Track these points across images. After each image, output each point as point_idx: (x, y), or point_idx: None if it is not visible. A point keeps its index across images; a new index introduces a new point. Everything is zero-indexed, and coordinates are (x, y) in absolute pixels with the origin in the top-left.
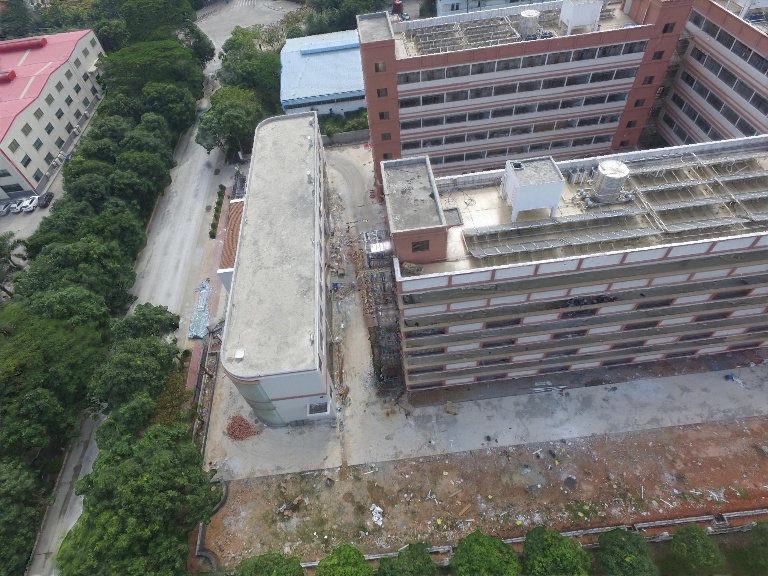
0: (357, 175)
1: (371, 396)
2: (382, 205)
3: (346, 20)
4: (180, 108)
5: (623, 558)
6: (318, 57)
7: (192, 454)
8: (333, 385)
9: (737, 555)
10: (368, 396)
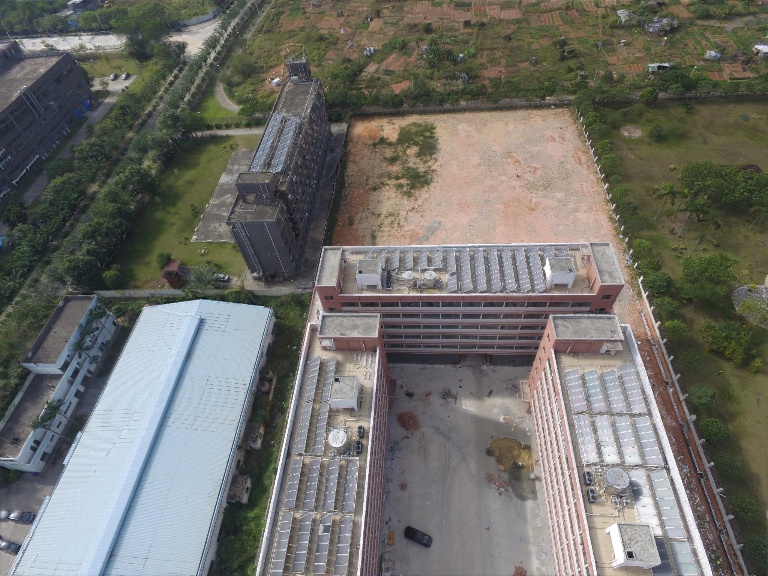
0: None
1: None
2: None
3: None
4: None
5: None
6: None
7: None
8: None
9: (724, 478)
10: None
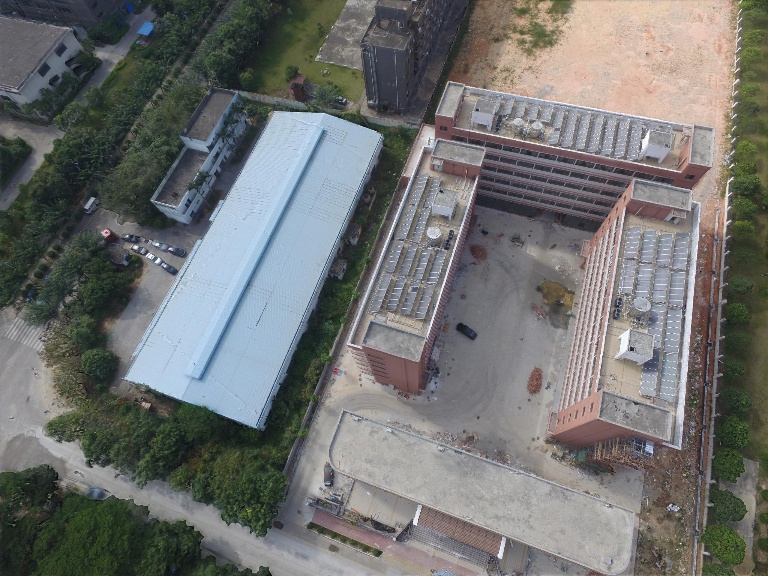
0: (372, 397)
1: (597, 479)
2: (421, 394)
3: (109, 299)
4: (190, 542)
5: (743, 404)
6: (215, 366)
7: None
8: None
9: (728, 351)
10: (596, 481)
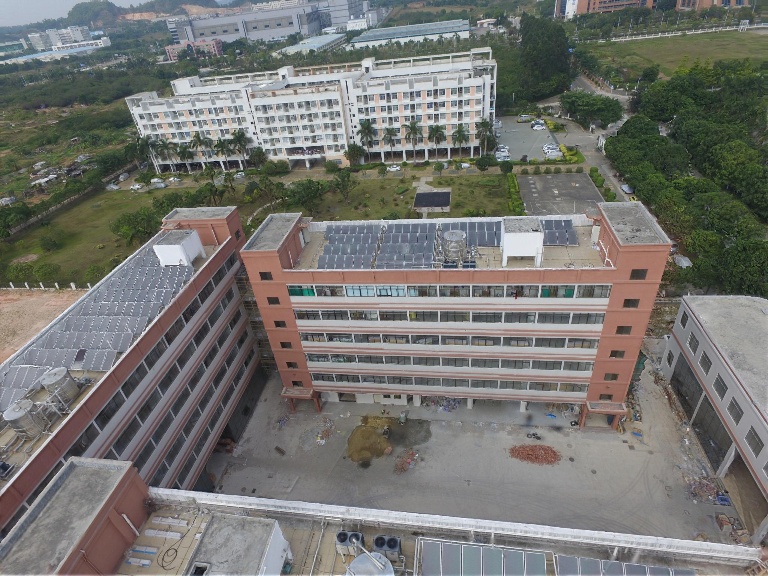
0: None
1: None
2: None
3: None
4: None
5: None
6: None
7: (762, 286)
8: (672, 376)
9: None
10: None
